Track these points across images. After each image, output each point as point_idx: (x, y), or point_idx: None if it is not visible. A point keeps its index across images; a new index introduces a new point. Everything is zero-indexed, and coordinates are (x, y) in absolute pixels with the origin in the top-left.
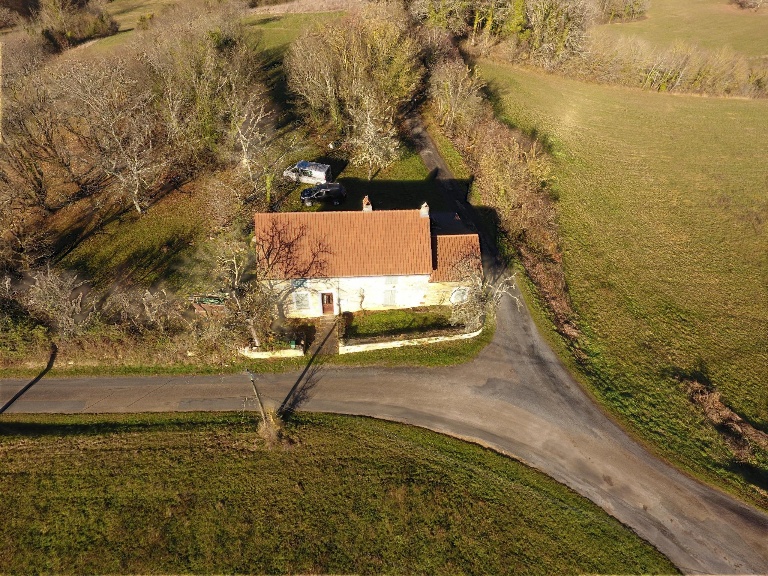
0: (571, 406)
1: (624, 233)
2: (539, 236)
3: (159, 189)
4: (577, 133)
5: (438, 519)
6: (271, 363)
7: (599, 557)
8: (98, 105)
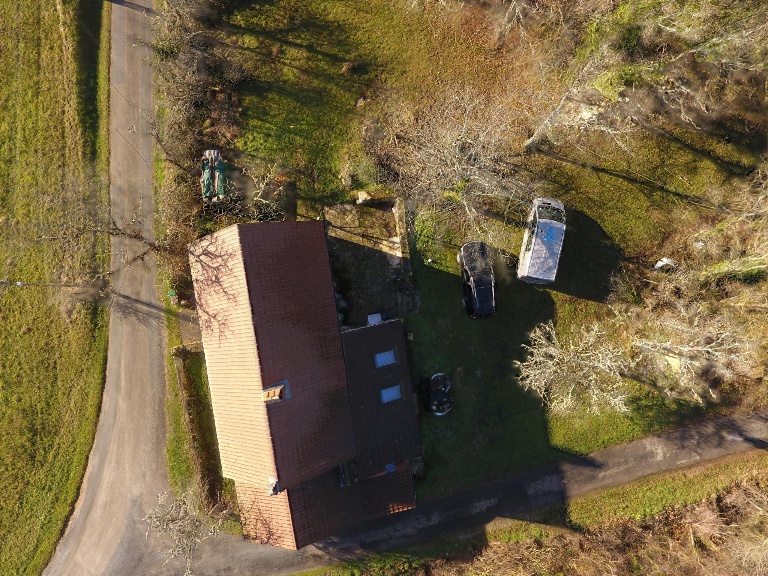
0: None
1: None
2: None
3: None
4: None
5: (1, 458)
6: None
7: None
8: None
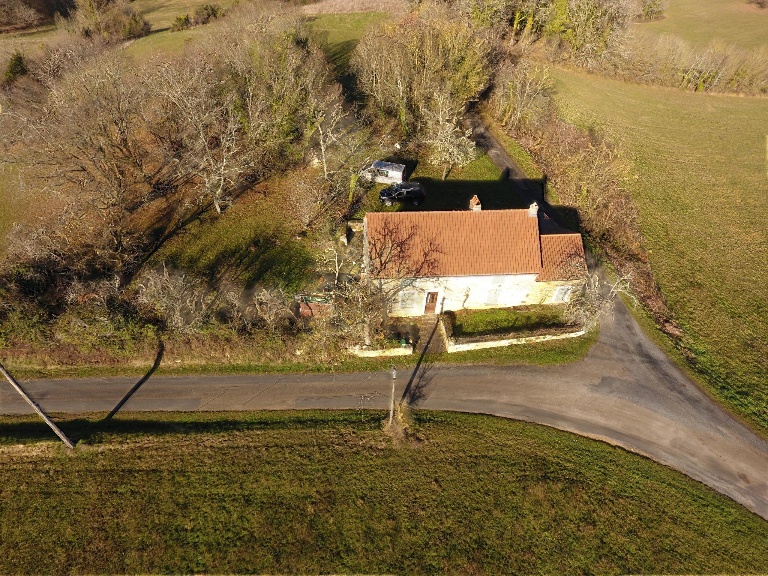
0: (691, 404)
1: (699, 233)
2: (624, 235)
3: (233, 189)
4: (631, 133)
5: (582, 516)
6: (380, 361)
7: (751, 554)
8: (186, 105)
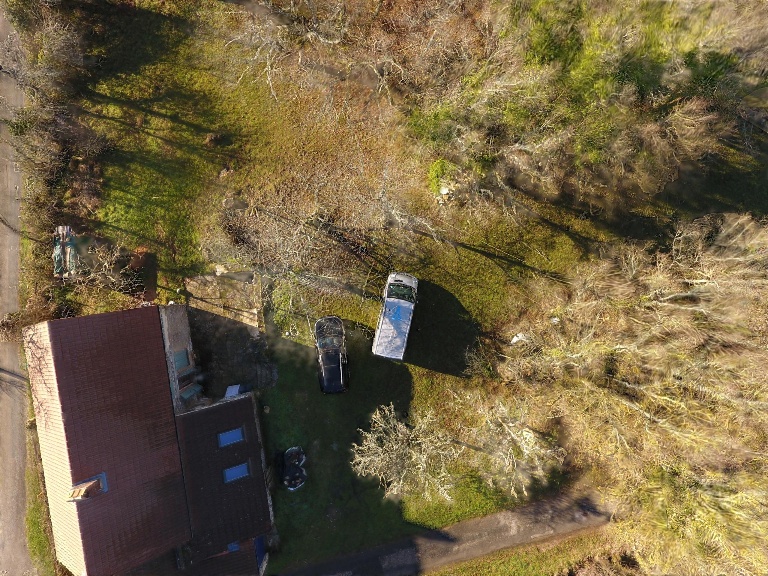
0: None
1: None
2: None
3: None
4: None
5: None
6: None
7: None
8: None
